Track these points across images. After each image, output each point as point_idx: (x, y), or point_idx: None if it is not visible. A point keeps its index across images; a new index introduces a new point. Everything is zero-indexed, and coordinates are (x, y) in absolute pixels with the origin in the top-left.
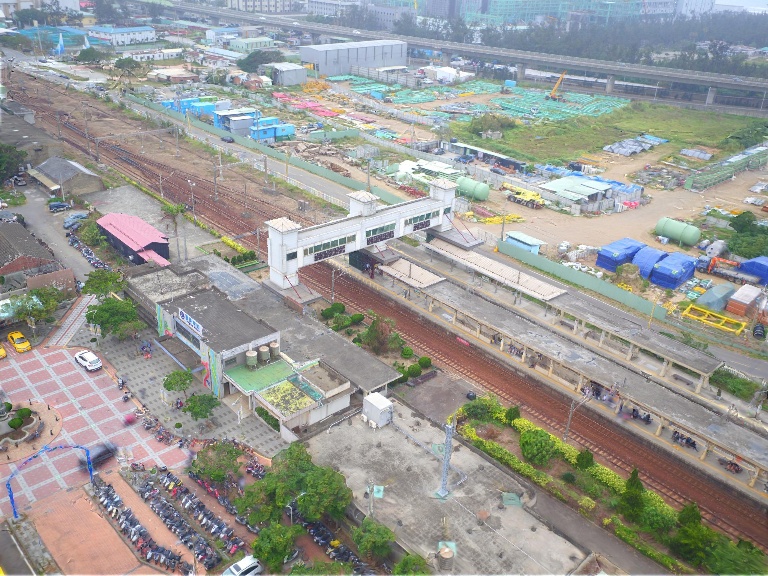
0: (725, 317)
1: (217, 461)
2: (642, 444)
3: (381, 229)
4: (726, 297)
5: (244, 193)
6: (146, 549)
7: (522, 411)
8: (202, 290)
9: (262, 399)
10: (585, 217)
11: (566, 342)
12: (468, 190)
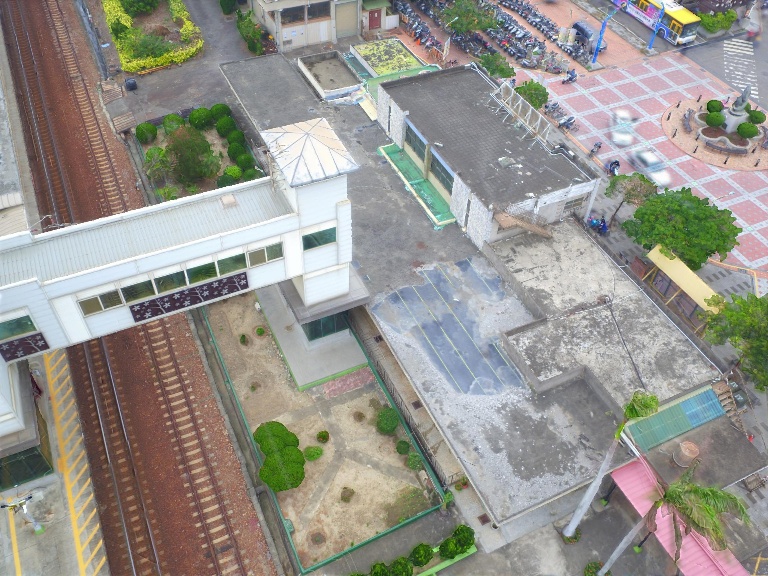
0: None
1: (473, 4)
2: (3, 22)
3: None
4: None
5: None
6: (527, 0)
7: (85, 70)
8: None
9: None
10: None
11: None
12: None
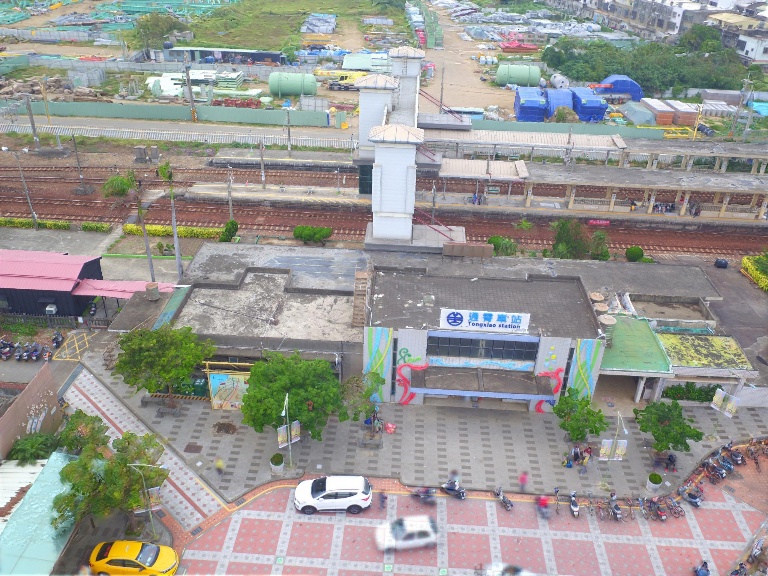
0: (671, 128)
1: None
2: None
3: None
4: (652, 111)
5: (15, 166)
6: None
7: None
8: None
9: (695, 369)
10: (422, 87)
11: (715, 174)
12: (293, 87)
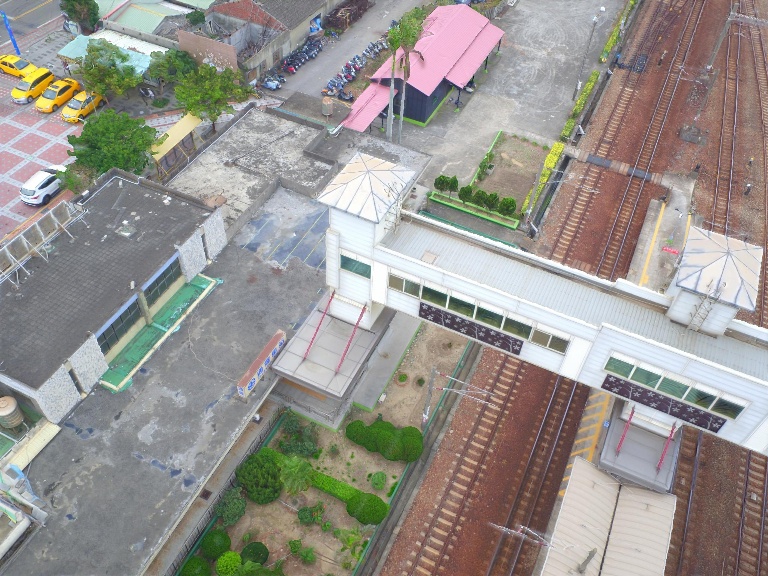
0: None
1: None
2: None
3: (678, 385)
4: None
5: None
6: None
7: None
8: (196, 201)
9: None
10: None
11: None
12: None
